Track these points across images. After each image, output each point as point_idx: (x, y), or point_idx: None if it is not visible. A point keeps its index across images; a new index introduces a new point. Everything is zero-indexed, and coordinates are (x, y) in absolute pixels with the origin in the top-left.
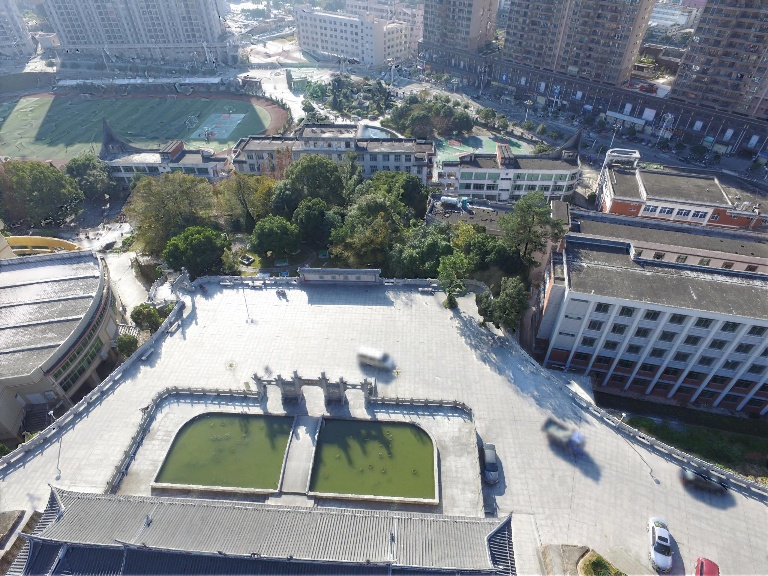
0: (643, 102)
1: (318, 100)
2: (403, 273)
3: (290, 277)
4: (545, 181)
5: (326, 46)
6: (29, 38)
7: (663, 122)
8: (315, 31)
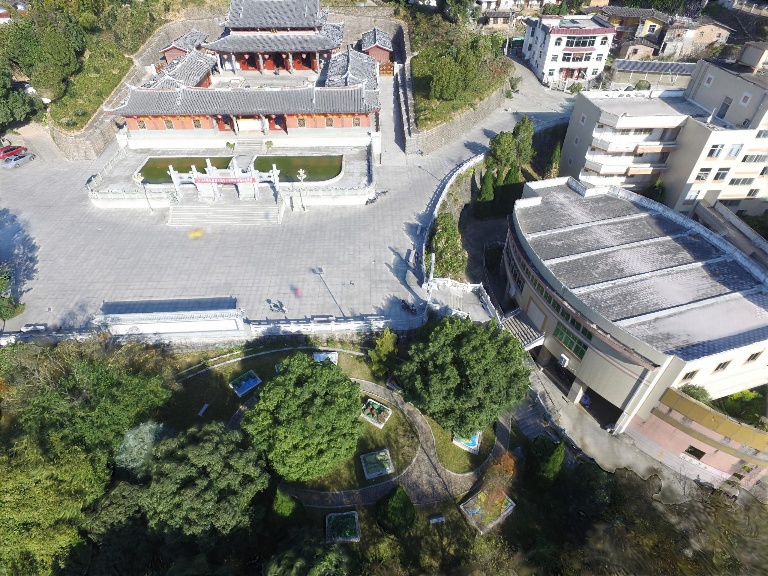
0: None
1: None
2: None
3: (263, 325)
4: None
5: None
6: None
7: None
8: None
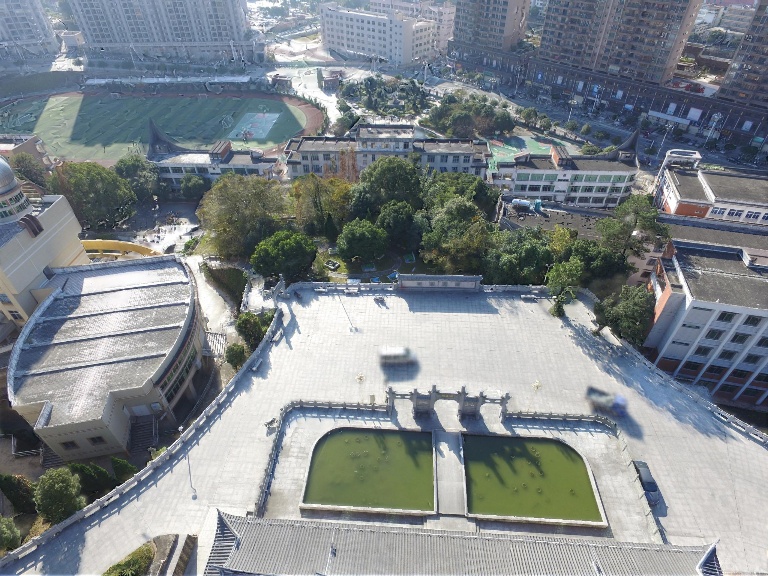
0: (688, 102)
1: (351, 99)
2: (502, 279)
3: (386, 283)
4: (603, 182)
5: (352, 44)
6: (54, 36)
7: (713, 122)
8: (341, 29)
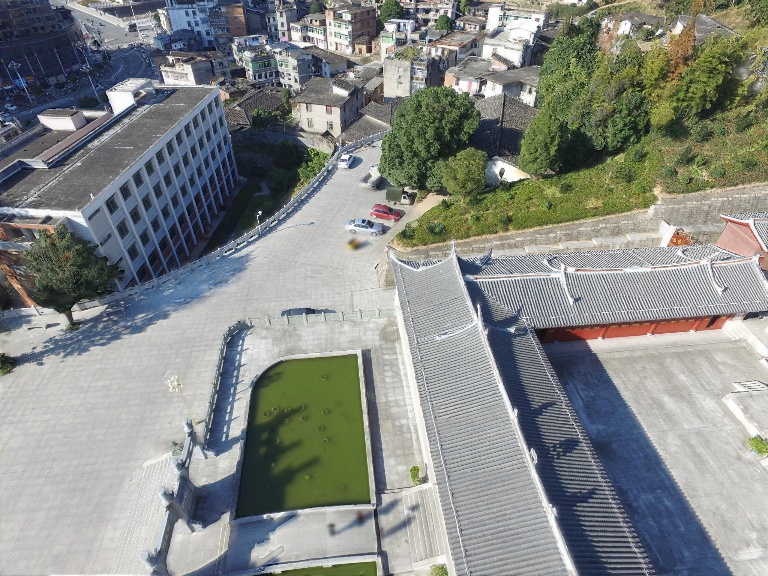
0: None
1: None
2: None
3: None
4: None
5: None
6: None
7: None
8: None
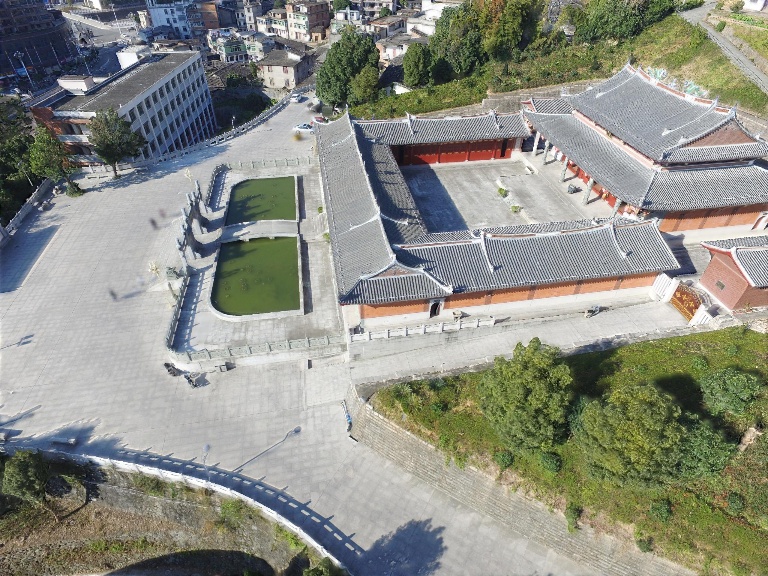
0: None
1: None
2: (2, 217)
3: None
4: None
5: None
6: None
7: None
8: None
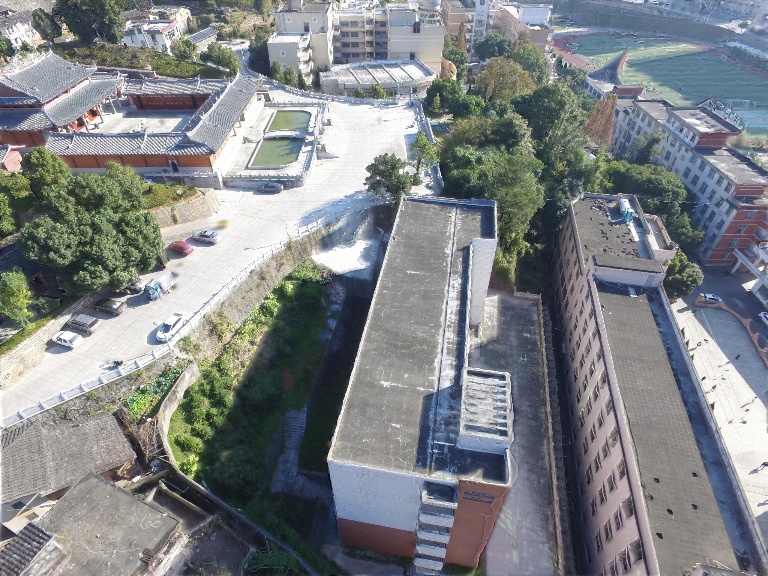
0: None
1: None
2: None
3: None
4: None
5: None
6: None
7: None
8: None
